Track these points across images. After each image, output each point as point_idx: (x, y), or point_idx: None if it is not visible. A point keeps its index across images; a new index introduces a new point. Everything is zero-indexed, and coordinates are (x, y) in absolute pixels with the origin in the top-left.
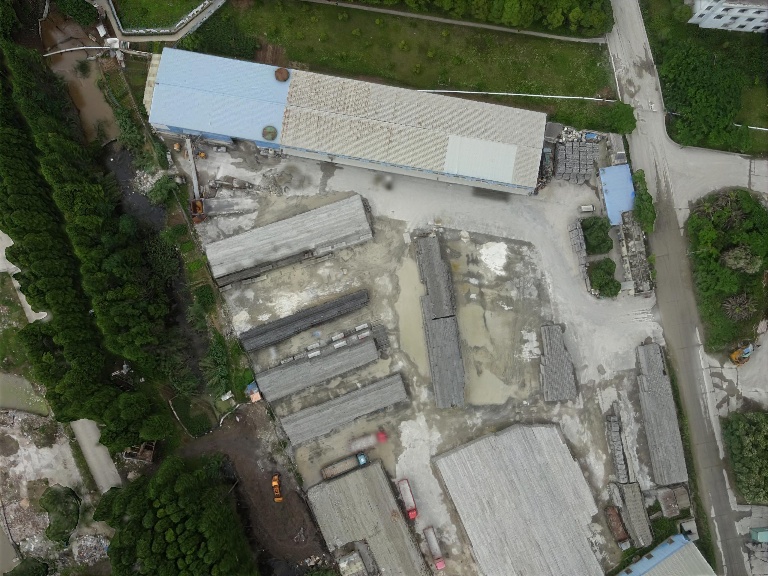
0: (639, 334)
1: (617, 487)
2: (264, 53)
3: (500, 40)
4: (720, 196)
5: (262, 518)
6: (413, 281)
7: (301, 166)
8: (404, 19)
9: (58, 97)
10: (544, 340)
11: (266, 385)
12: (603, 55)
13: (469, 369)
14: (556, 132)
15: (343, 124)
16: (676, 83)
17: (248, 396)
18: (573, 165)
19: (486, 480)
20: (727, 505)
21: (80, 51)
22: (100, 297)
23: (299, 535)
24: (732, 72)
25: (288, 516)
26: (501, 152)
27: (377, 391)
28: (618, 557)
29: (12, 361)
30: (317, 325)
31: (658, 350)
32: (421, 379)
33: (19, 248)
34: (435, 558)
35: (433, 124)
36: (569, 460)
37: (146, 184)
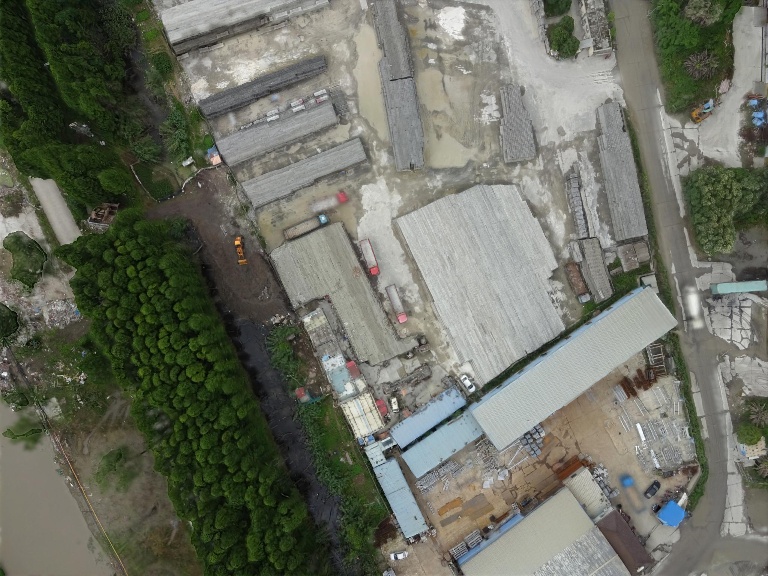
0: (599, 96)
1: (577, 243)
2: None
3: None
4: None
5: (227, 278)
6: (371, 47)
7: None
8: None
9: None
10: (503, 101)
11: (226, 147)
12: None
13: (429, 133)
14: None
15: None
16: None
17: (209, 162)
18: None
19: (446, 237)
20: (688, 262)
21: None
22: (53, 47)
23: (263, 293)
24: None
25: (252, 277)
26: None
27: (336, 152)
28: (579, 313)
29: None
30: (275, 92)
31: (617, 107)
32: (381, 143)
33: None
34: (397, 313)
35: None
36: (529, 216)
37: None
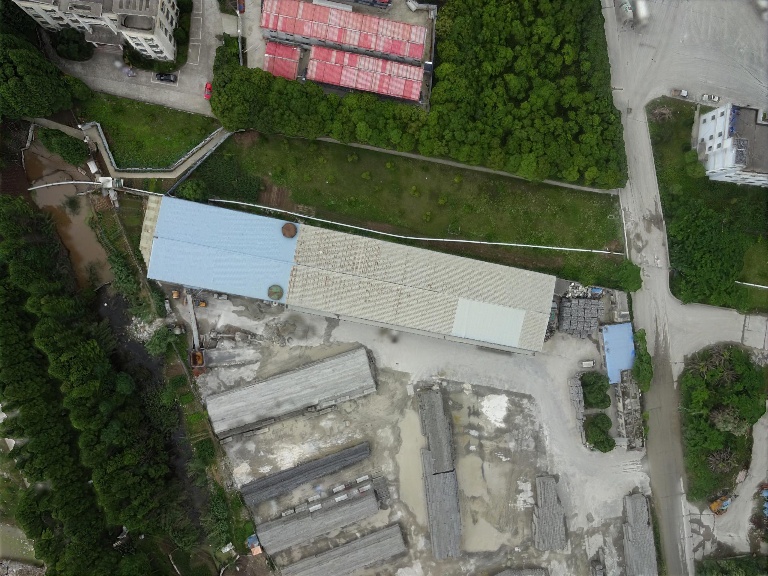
0: (628, 484)
1: None
2: (268, 194)
3: (513, 188)
4: (714, 353)
5: None
6: (415, 433)
7: (305, 315)
8: (416, 162)
9: (47, 241)
10: (539, 492)
11: (267, 540)
12: (614, 207)
13: (465, 518)
14: (563, 289)
15: (352, 285)
16: (684, 246)
17: (248, 547)
18: (578, 323)
19: None
20: None
21: (68, 185)
22: (100, 471)
23: None
24: (738, 235)
25: None
26: (509, 316)
27: (376, 544)
28: None
29: (4, 511)
30: (318, 477)
31: (645, 503)
32: (419, 528)
33: (13, 425)
34: None
35: (443, 286)
36: None
37: (143, 333)
